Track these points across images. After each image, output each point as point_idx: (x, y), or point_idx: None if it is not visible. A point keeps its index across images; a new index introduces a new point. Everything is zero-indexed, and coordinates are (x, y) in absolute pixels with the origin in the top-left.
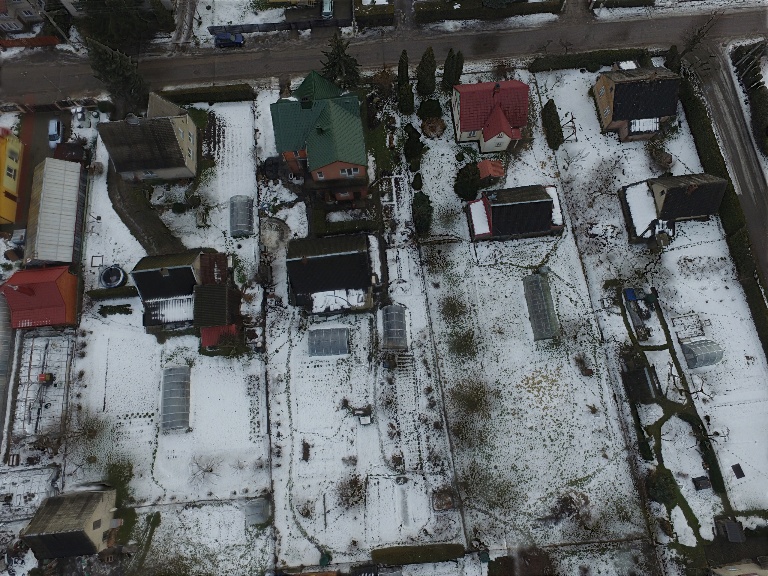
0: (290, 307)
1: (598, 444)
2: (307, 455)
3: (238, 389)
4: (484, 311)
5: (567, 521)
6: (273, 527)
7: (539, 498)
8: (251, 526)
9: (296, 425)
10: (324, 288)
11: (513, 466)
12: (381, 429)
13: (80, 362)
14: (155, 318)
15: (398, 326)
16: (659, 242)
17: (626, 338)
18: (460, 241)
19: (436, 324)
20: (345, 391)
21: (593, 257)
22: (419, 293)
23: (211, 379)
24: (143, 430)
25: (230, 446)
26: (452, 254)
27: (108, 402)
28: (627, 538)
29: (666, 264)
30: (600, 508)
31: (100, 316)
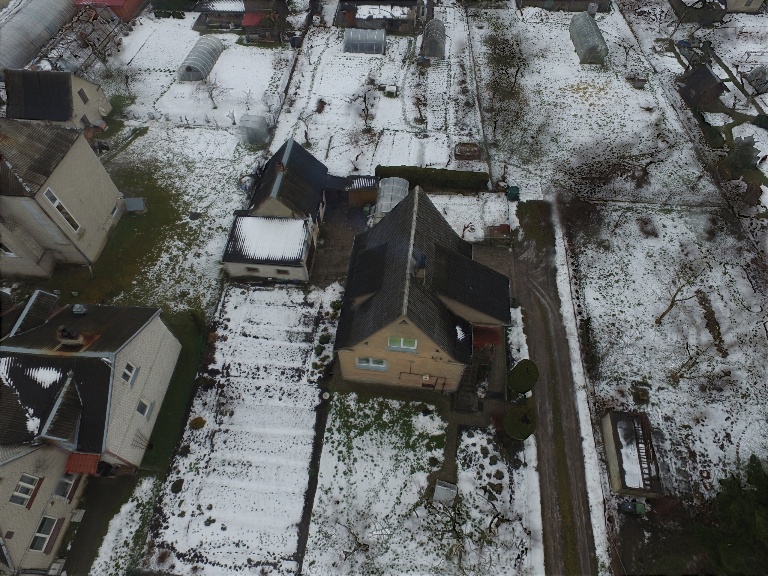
0: (333, 27)
1: (655, 134)
2: (321, 108)
3: (265, 65)
4: (527, 45)
5: (619, 181)
6: (267, 150)
7: (584, 163)
8: (243, 148)
9: (316, 91)
10: (370, 1)
11: (553, 139)
12: (406, 101)
13: (122, 38)
14: (205, 7)
15: (438, 31)
16: (711, 6)
17: (682, 71)
18: (507, 8)
19: (476, 48)
20: (374, 75)
21: (642, 25)
22: (462, 30)
23: (241, 57)
24: (159, 79)
25: (242, 95)
26: (498, 14)
27: (135, 60)
28: (699, 205)
29: (721, 34)
30: (661, 178)
31: (154, 18)
